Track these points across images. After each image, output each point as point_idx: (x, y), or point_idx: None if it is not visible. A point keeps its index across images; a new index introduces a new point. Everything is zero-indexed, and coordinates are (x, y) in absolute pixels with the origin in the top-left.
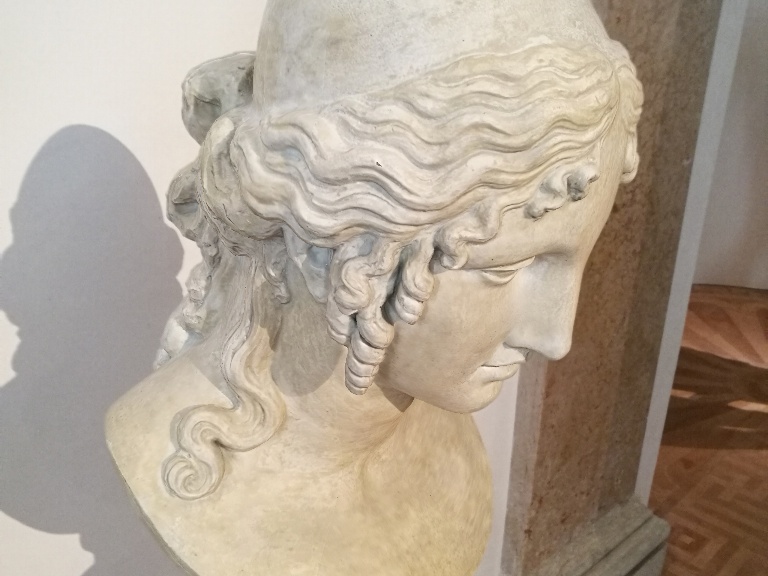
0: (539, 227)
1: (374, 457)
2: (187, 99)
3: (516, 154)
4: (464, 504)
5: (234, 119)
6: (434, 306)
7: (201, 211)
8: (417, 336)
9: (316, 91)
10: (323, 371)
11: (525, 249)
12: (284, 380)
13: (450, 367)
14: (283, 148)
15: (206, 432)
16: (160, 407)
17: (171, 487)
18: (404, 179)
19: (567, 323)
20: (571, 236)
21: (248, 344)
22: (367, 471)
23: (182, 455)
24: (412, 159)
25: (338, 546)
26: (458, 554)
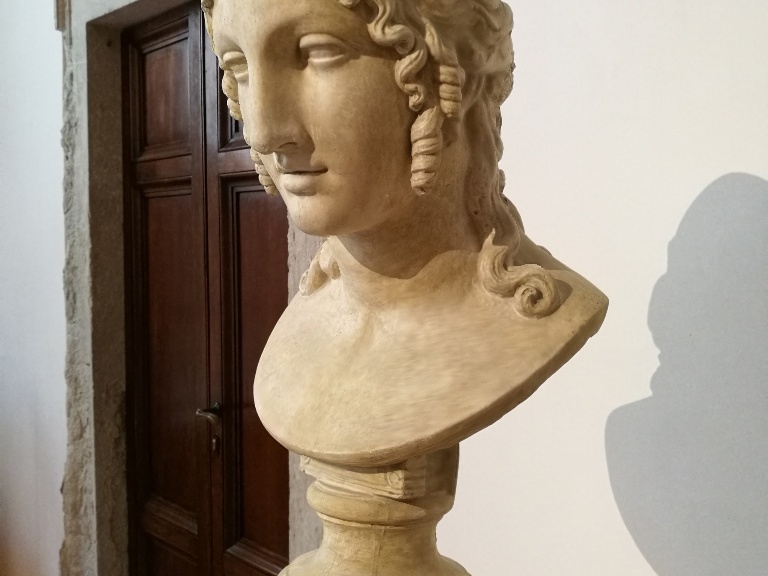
0: None
1: (378, 322)
2: None
3: None
4: (401, 404)
5: None
6: None
7: None
8: None
9: None
10: None
11: None
12: None
13: None
14: None
15: None
16: None
17: None
18: None
19: None
20: (227, 27)
21: None
22: (373, 333)
23: None
24: None
25: None
26: (352, 427)
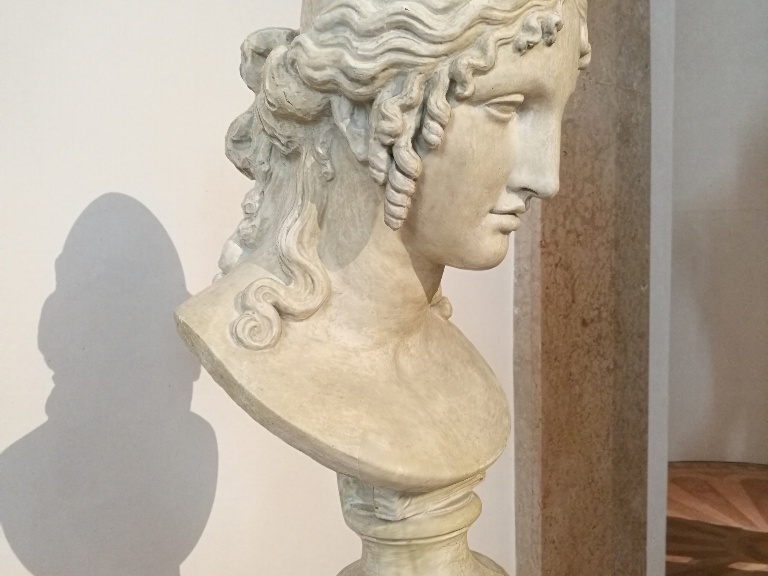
0: (524, 62)
1: (404, 348)
2: (246, 53)
3: None
4: (484, 402)
5: (287, 46)
6: (451, 138)
7: (255, 140)
8: (439, 171)
9: None
10: (362, 237)
11: (516, 79)
12: (329, 256)
13: (466, 204)
14: (333, 27)
15: (266, 296)
16: (224, 290)
17: (239, 336)
18: (425, 18)
19: (554, 161)
20: (548, 78)
21: (300, 220)
22: (399, 360)
23: (247, 313)
24: (430, 8)
25: (381, 403)
26: (484, 434)
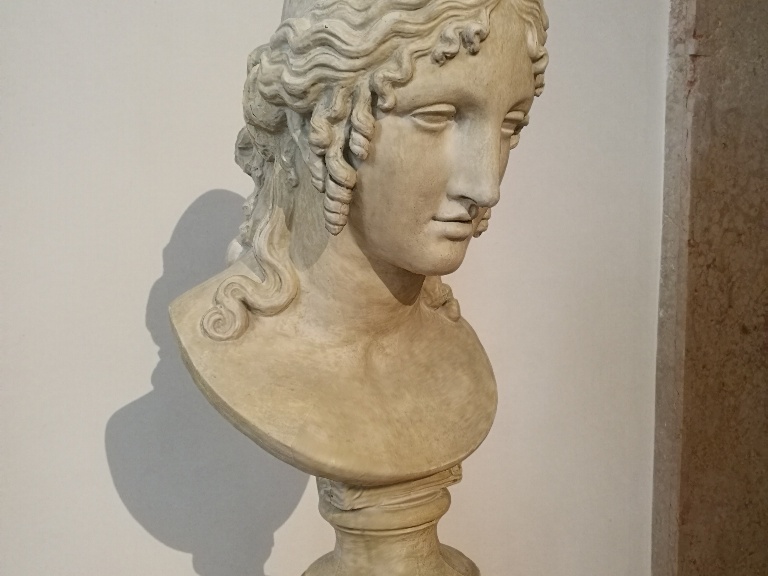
0: (445, 72)
1: (378, 347)
2: (248, 67)
3: (417, 11)
4: (462, 406)
5: None
6: (380, 148)
7: (254, 148)
8: (373, 179)
9: (302, 6)
10: (322, 240)
11: (436, 90)
12: (298, 257)
13: (403, 211)
14: (280, 45)
15: (236, 292)
16: (210, 285)
17: (204, 327)
18: (342, 35)
19: (490, 170)
20: (476, 86)
21: (270, 223)
22: (372, 359)
23: (216, 307)
24: (350, 25)
25: (333, 398)
26: (447, 437)
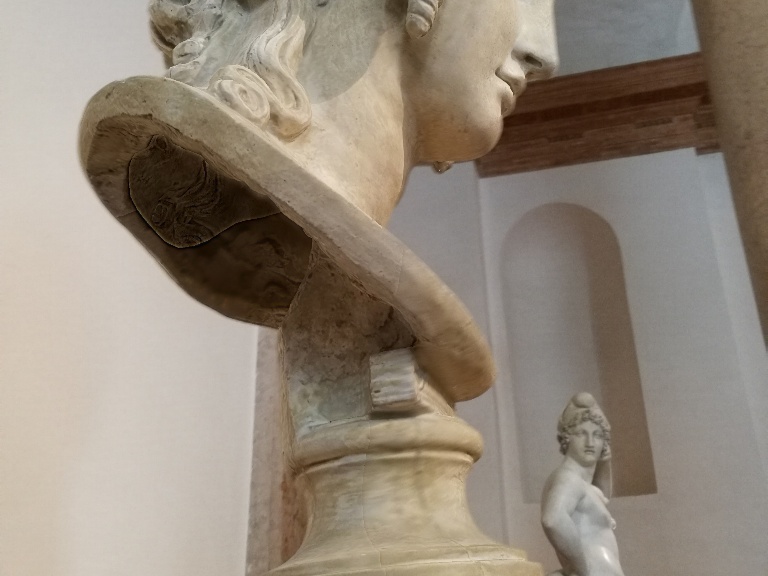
0: None
1: None
2: None
3: None
4: None
5: None
6: None
7: None
8: None
9: None
10: (358, 67)
11: None
12: (311, 85)
13: (484, 43)
14: None
15: None
16: None
17: (226, 91)
18: None
19: (554, 39)
20: None
21: (285, 32)
22: None
23: None
24: None
25: None
26: None
